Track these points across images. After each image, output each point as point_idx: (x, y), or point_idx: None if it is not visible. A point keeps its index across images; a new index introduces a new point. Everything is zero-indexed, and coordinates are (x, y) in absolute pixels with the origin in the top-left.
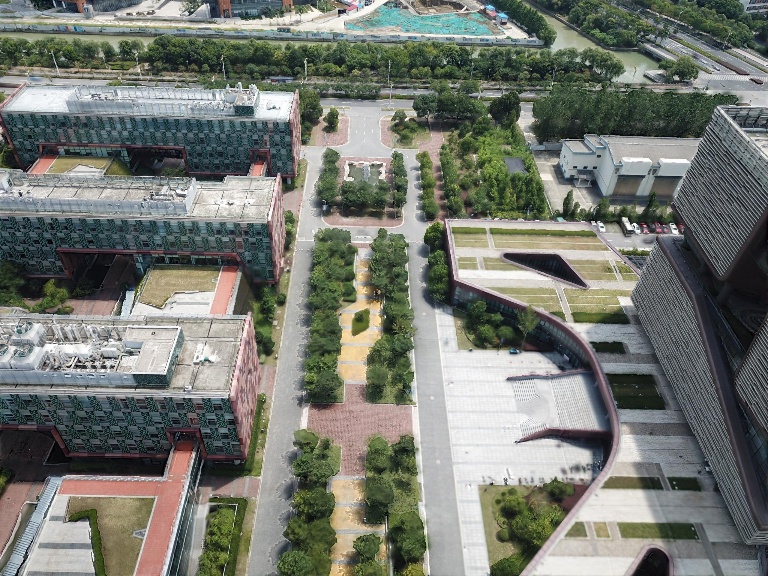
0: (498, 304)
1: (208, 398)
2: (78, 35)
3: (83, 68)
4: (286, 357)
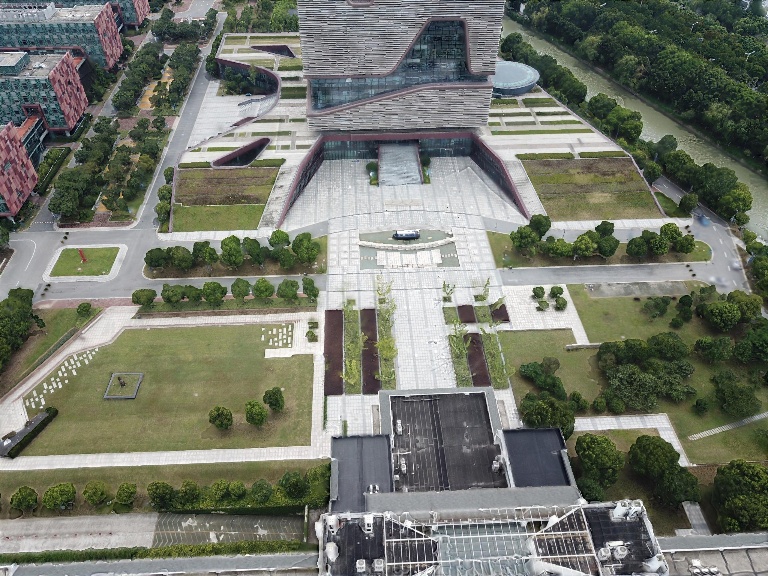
0: (241, 70)
1: (38, 79)
2: None
3: None
4: (110, 102)
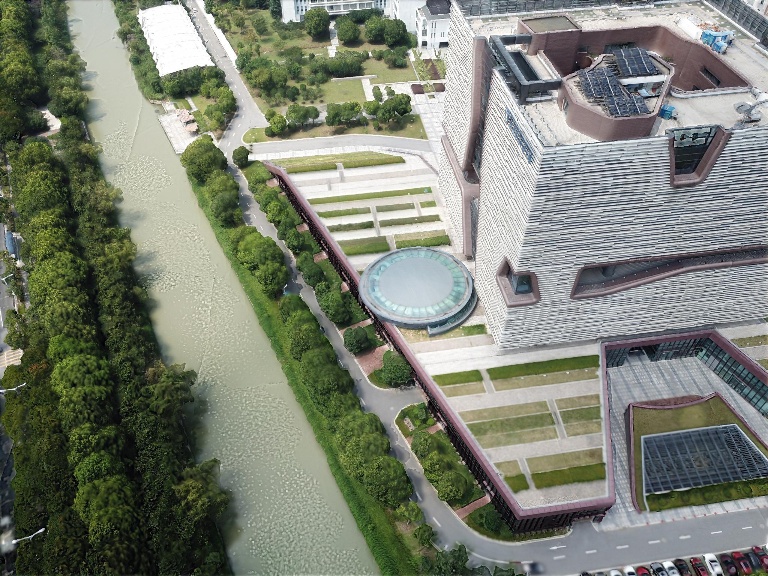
0: None
1: None
2: None
3: None
4: None
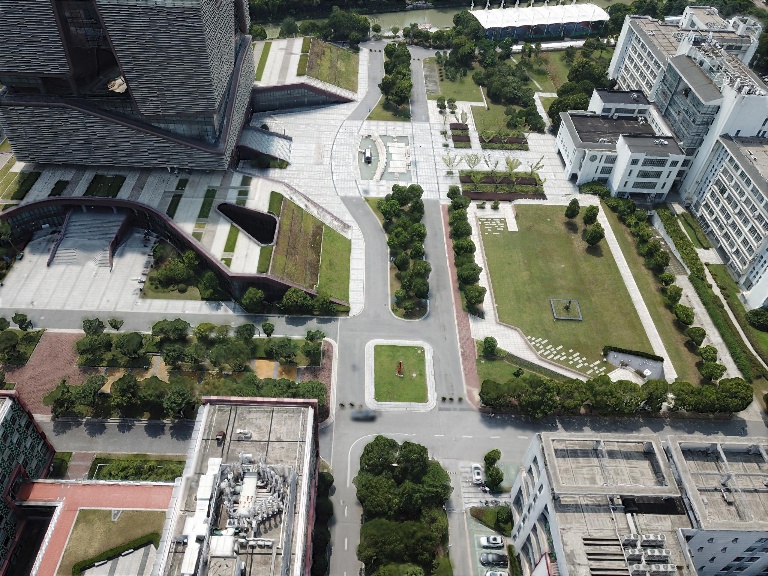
0: None
1: (4, 419)
2: None
3: None
4: None
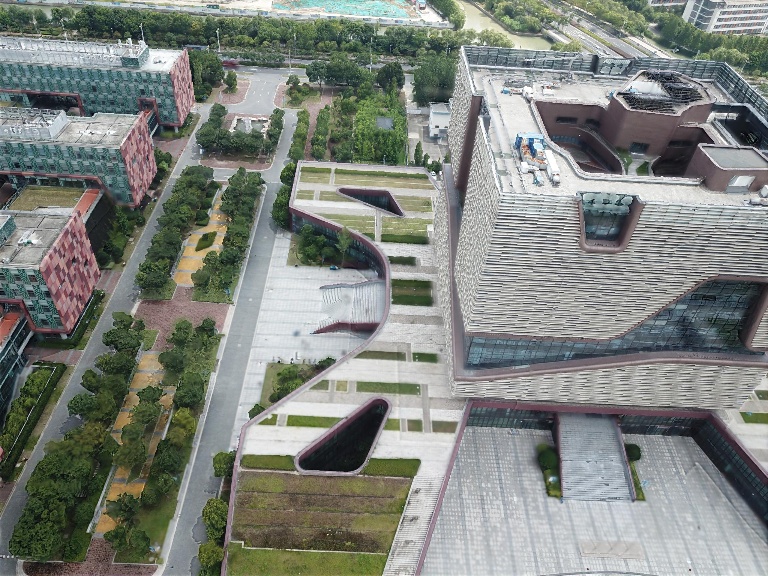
0: (324, 228)
1: (22, 269)
2: (20, 5)
3: (16, 32)
4: (133, 265)
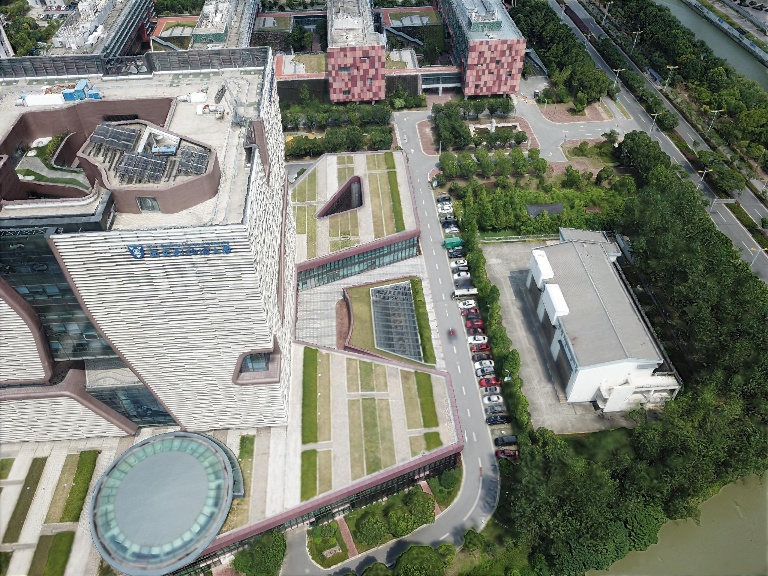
0: None
1: None
2: None
3: (601, 3)
4: None
